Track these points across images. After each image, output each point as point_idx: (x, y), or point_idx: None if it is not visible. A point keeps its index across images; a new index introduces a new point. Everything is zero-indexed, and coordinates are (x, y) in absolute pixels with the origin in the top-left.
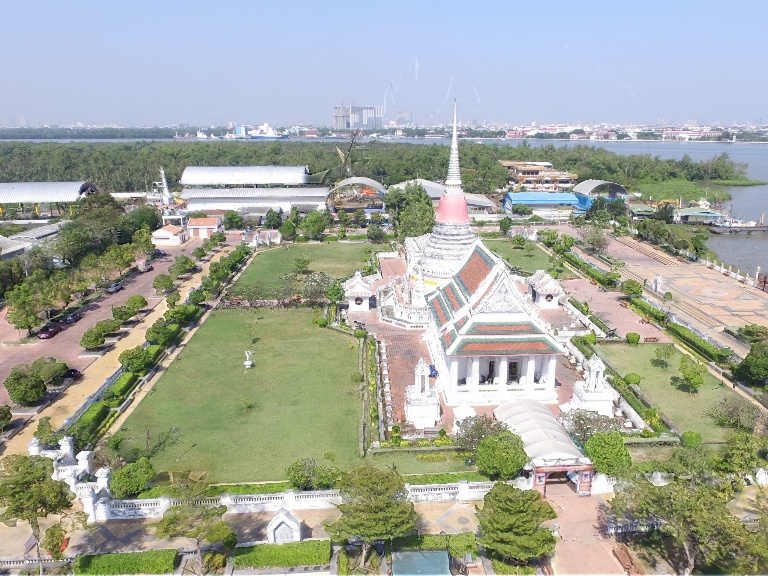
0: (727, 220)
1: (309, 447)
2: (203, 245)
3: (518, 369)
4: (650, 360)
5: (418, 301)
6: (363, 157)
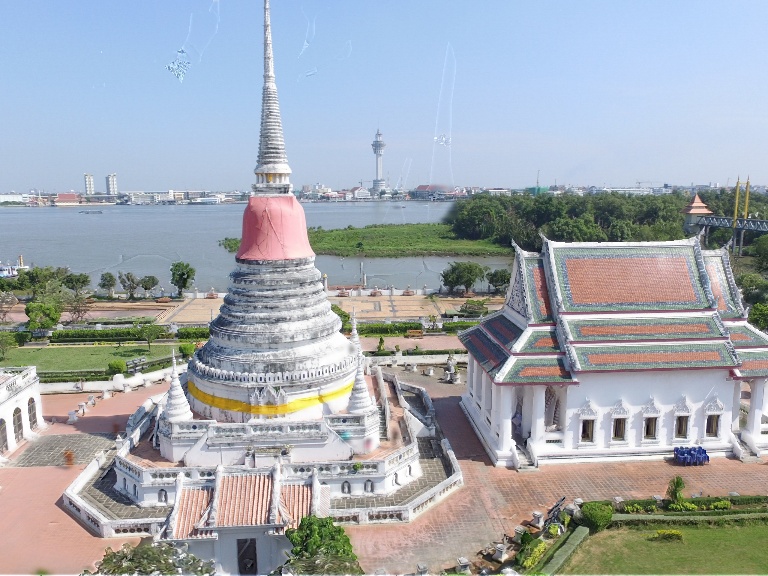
0: (4, 268)
1: None
2: None
3: None
4: None
5: (377, 435)
6: None
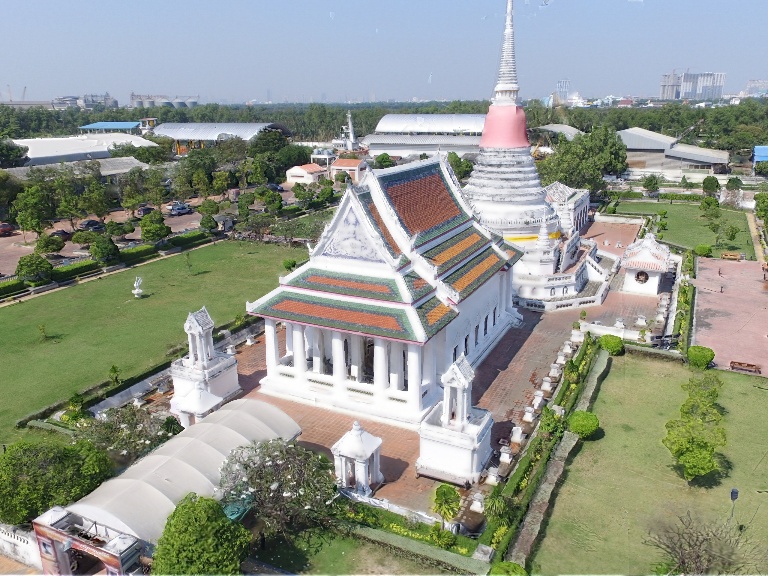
0: None
1: (4, 397)
2: (313, 182)
3: (405, 361)
4: None
5: None
6: (566, 100)
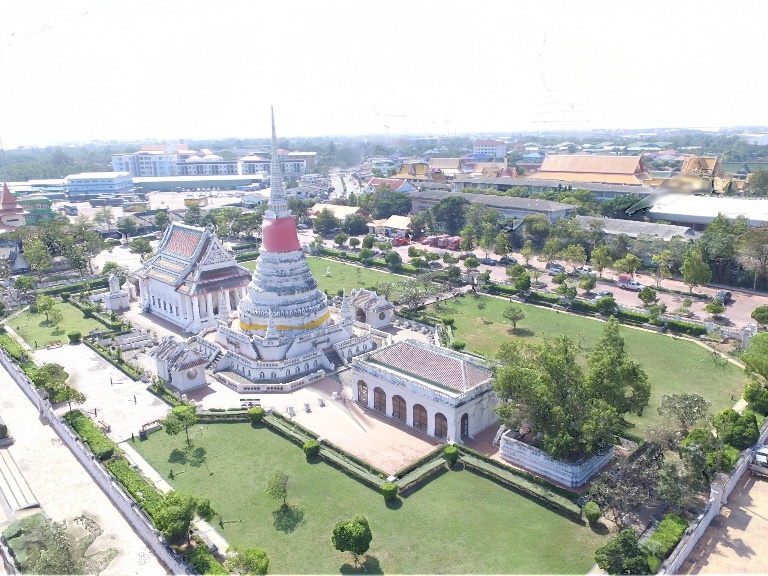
0: None
1: None
2: None
3: None
4: (66, 333)
5: None
6: None
